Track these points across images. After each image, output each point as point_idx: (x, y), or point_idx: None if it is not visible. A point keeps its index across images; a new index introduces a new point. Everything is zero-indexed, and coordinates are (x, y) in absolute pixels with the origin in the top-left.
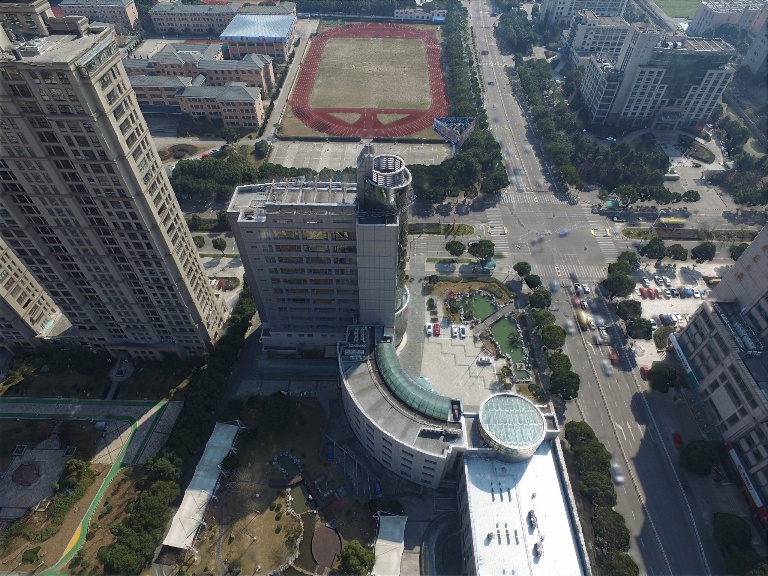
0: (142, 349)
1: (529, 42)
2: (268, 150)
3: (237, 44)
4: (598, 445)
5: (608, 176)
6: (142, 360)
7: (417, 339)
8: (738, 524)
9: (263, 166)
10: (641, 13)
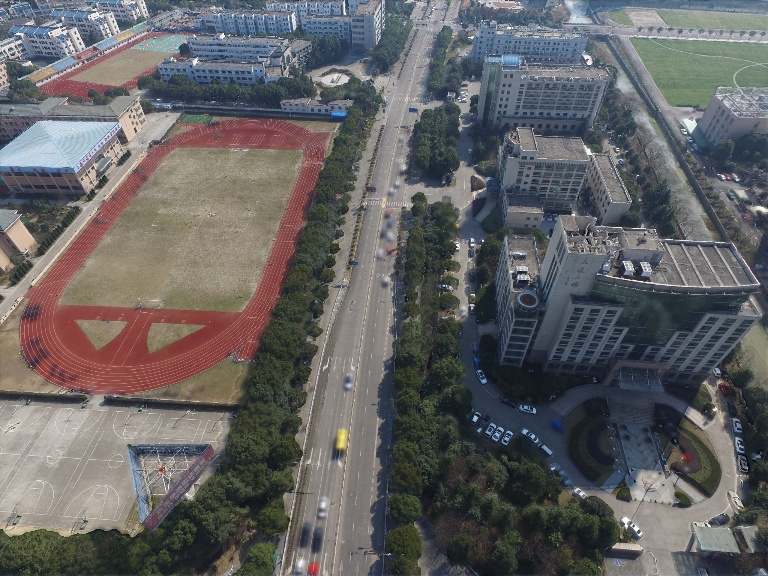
0: None
1: (446, 165)
2: None
3: (12, 174)
4: None
5: (487, 561)
6: None
7: None
8: None
9: None
10: (628, 103)
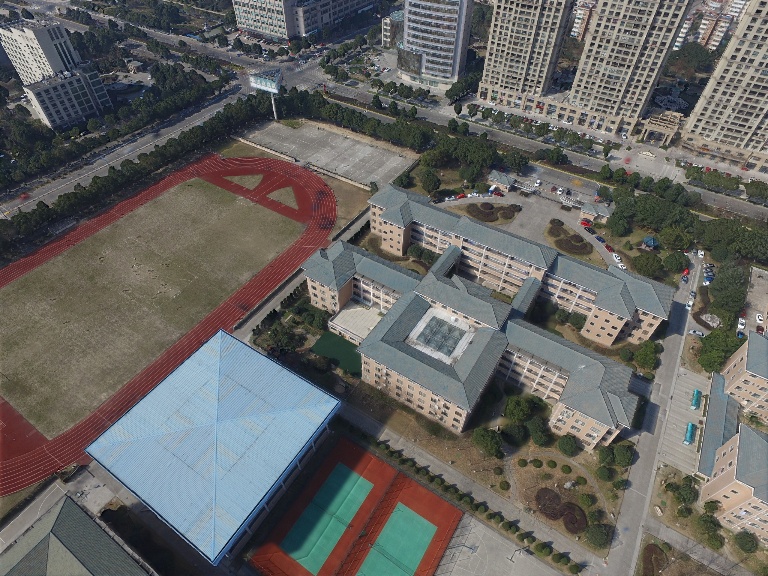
0: None
1: None
2: None
3: None
4: (373, 27)
5: None
6: None
7: (396, 70)
8: (358, 14)
9: (421, 132)
10: None
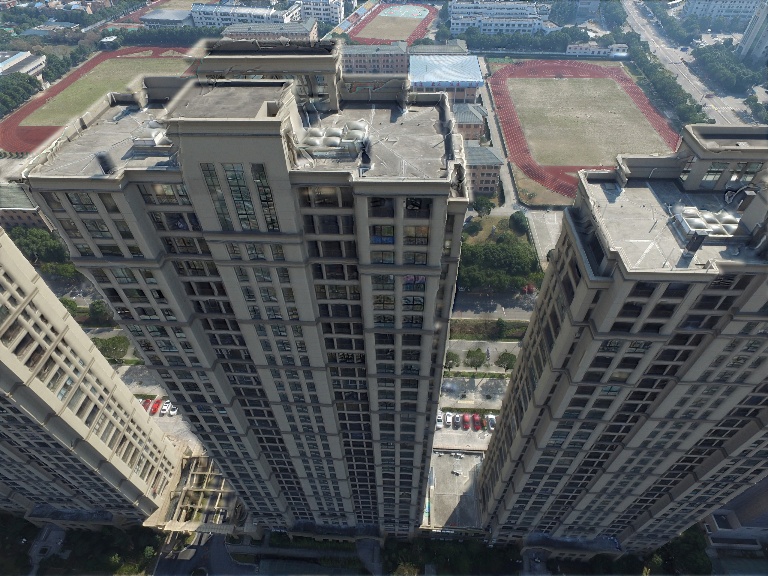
0: (573, 551)
1: (751, 82)
2: (527, 224)
3: (424, 89)
4: None
5: None
6: (559, 560)
7: None
8: None
9: None
10: None
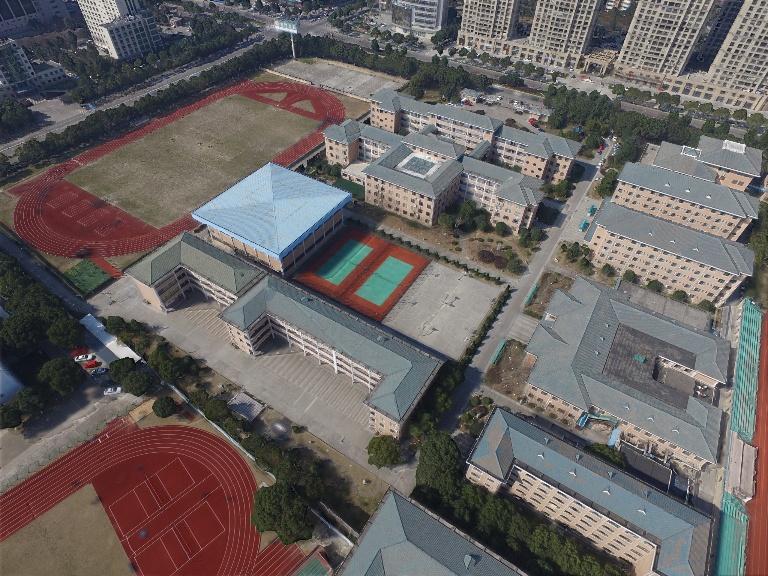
0: None
1: None
2: None
3: None
4: None
5: None
6: None
7: None
8: None
9: (410, 61)
10: None
